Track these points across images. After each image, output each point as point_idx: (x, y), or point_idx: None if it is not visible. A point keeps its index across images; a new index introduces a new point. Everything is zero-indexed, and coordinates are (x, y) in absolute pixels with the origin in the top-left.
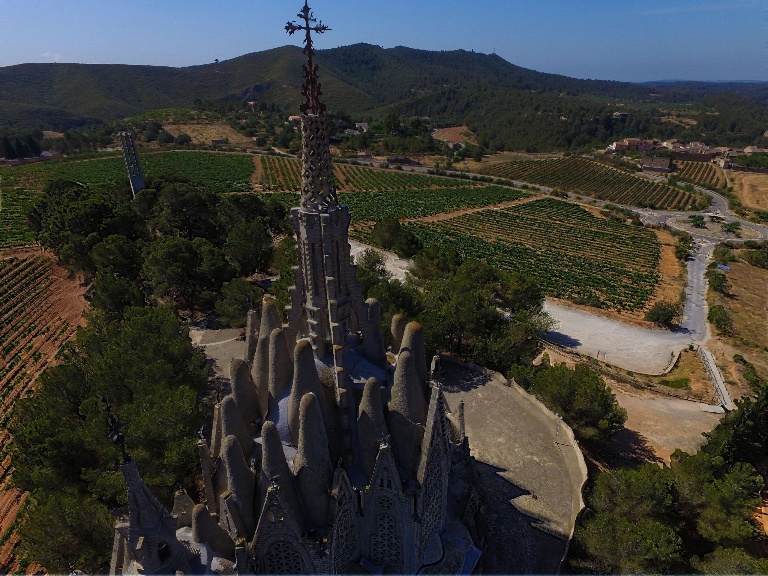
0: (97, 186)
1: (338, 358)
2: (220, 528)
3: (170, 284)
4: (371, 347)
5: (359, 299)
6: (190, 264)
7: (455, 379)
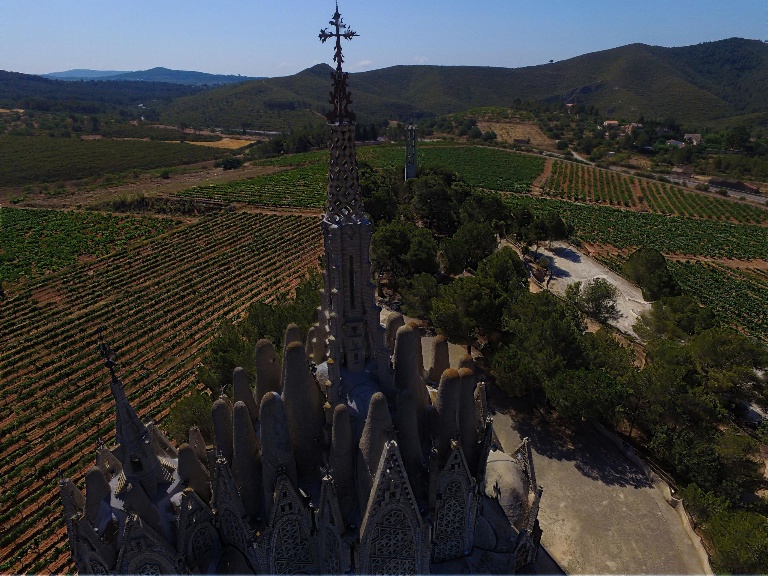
0: (383, 170)
1: (330, 372)
2: (202, 472)
3: (379, 263)
4: (384, 376)
5: (374, 321)
6: (399, 250)
7: (602, 463)
